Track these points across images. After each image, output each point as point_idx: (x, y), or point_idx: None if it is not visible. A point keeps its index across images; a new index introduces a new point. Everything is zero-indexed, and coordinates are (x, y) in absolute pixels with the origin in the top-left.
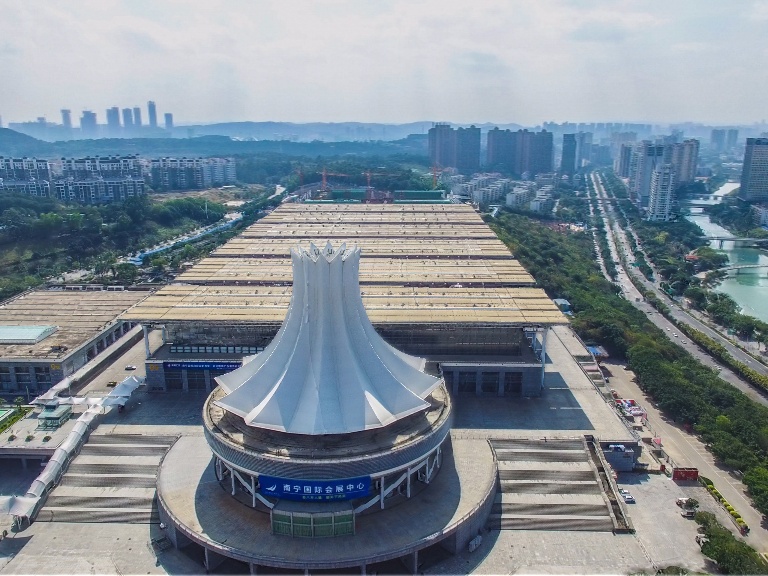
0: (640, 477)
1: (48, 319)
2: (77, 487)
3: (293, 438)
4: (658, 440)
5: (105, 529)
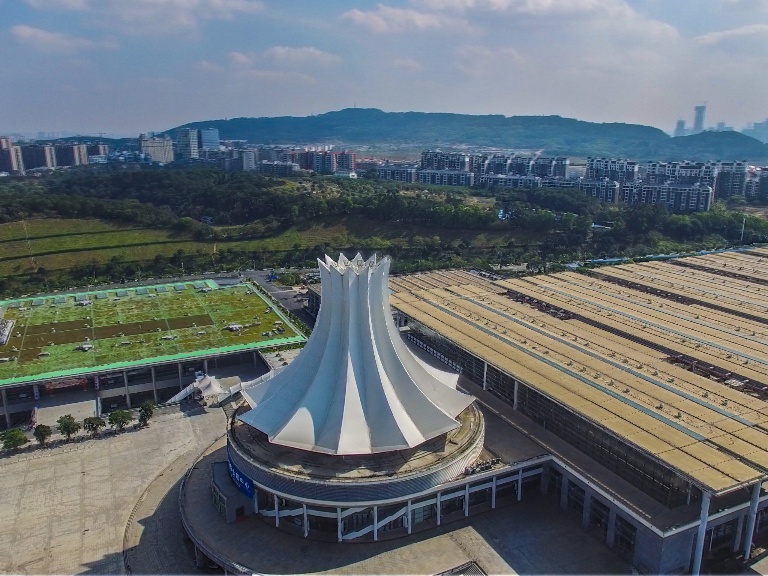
0: None
1: None
2: None
3: None
4: None
5: None
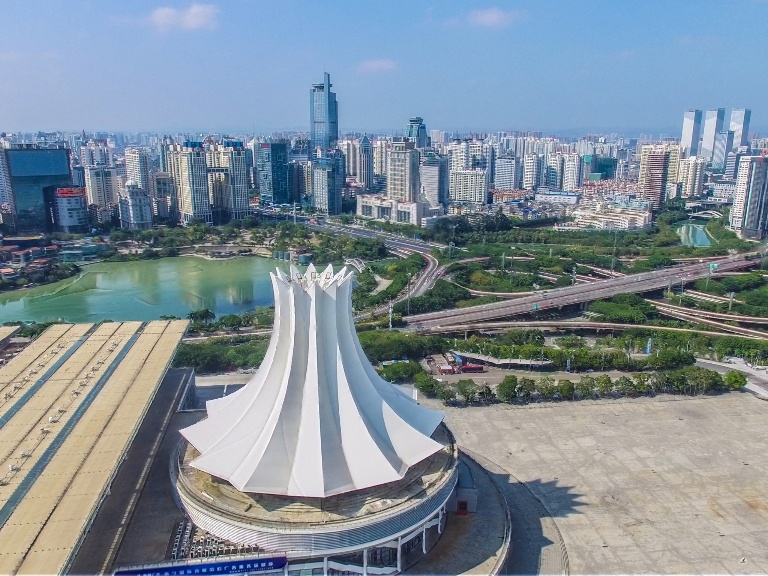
0: None
1: None
2: None
3: None
4: None
5: None
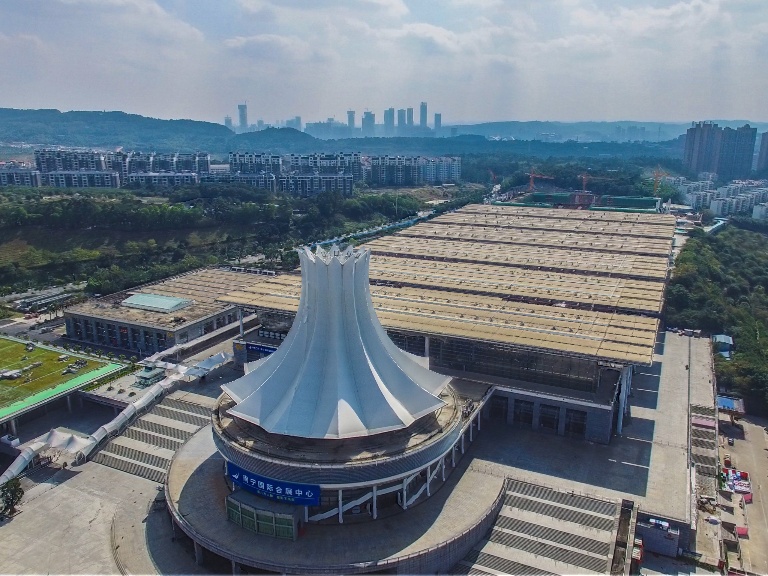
0: (682, 567)
1: (196, 294)
2: (133, 439)
3: (266, 432)
4: (743, 529)
5: (131, 480)
